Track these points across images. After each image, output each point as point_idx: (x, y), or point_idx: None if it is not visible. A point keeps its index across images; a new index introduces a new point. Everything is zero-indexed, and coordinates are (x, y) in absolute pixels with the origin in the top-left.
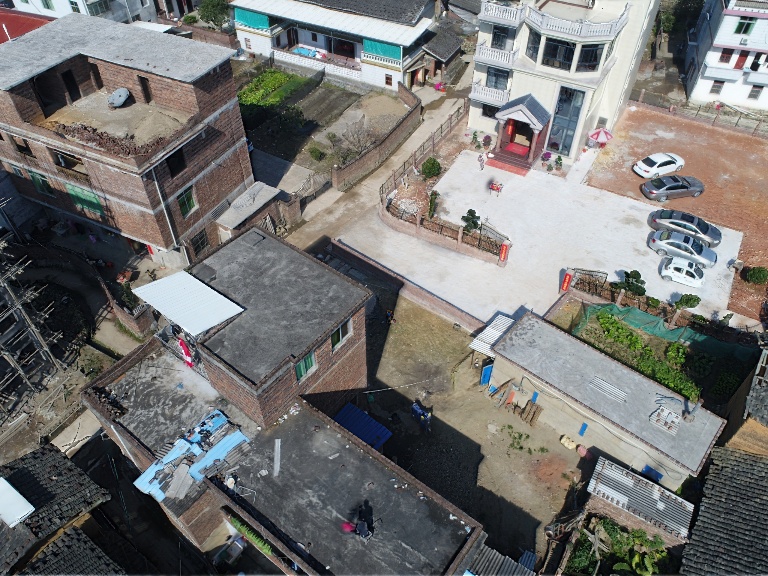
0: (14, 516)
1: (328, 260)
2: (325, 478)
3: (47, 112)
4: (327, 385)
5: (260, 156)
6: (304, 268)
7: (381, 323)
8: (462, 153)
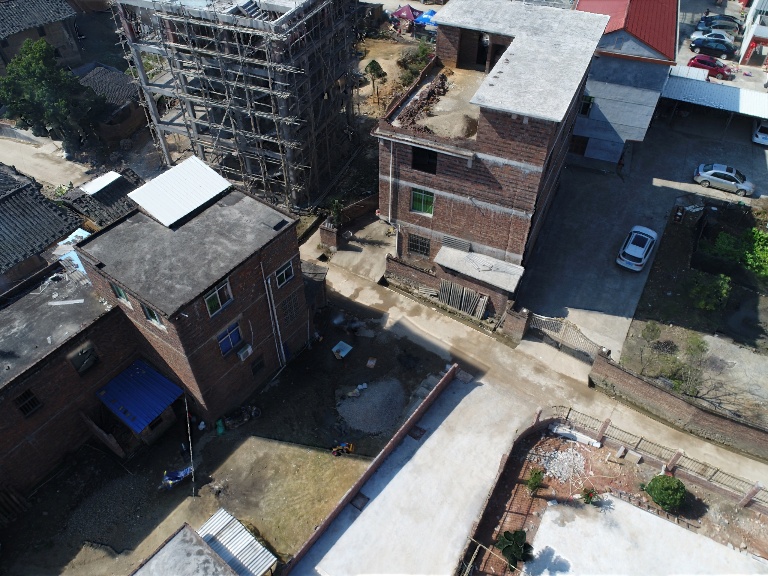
0: (89, 188)
1: (441, 375)
2: (31, 335)
3: (470, 66)
4: (151, 340)
5: (632, 282)
6: (223, 263)
7: (334, 439)
8: (760, 560)
